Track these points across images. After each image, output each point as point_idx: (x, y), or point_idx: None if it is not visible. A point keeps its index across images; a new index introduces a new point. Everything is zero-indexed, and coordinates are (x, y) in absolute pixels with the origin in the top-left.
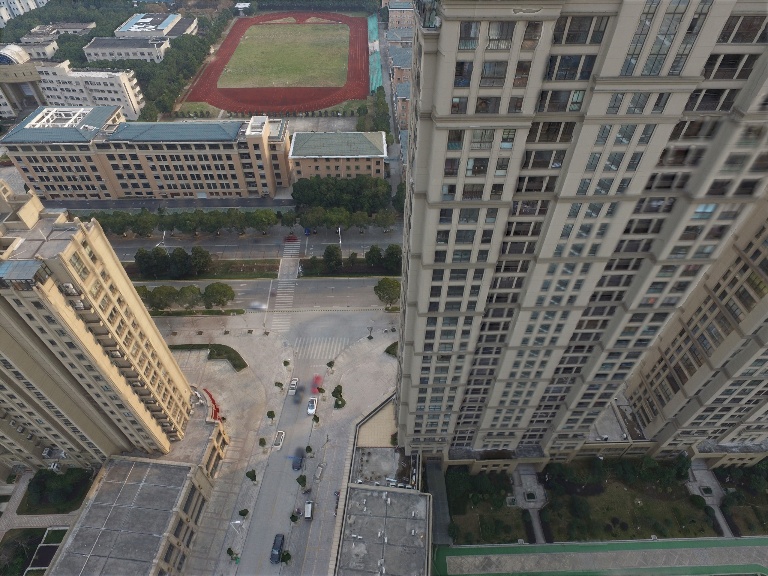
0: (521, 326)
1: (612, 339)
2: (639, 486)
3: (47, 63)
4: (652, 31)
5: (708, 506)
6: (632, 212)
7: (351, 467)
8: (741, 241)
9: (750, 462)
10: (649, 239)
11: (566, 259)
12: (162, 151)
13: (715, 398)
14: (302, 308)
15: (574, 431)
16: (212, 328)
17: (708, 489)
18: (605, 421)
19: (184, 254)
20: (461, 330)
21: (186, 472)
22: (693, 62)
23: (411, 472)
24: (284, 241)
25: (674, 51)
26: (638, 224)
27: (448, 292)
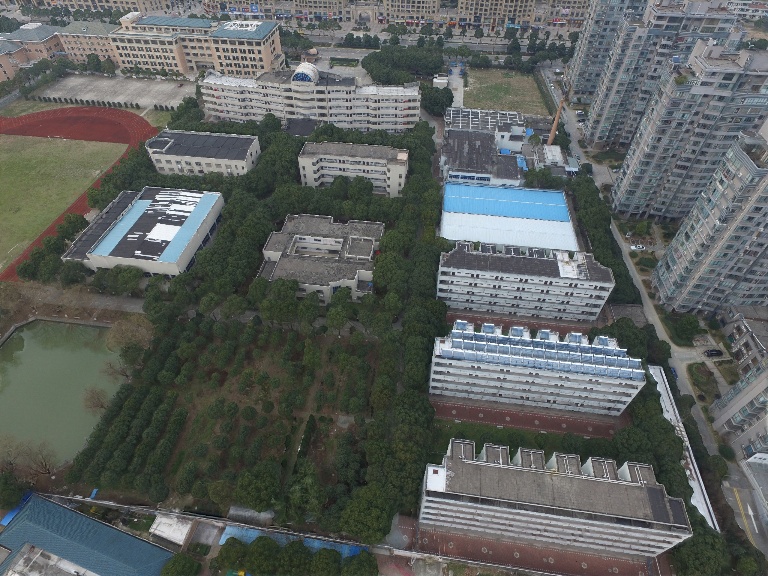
0: None
1: None
2: None
3: (275, 81)
4: None
5: None
6: None
7: None
8: None
9: None
10: None
11: None
12: None
13: None
14: None
15: None
16: None
17: None
18: None
19: None
20: None
21: None
22: None
23: None
24: None
25: None
26: None
27: None
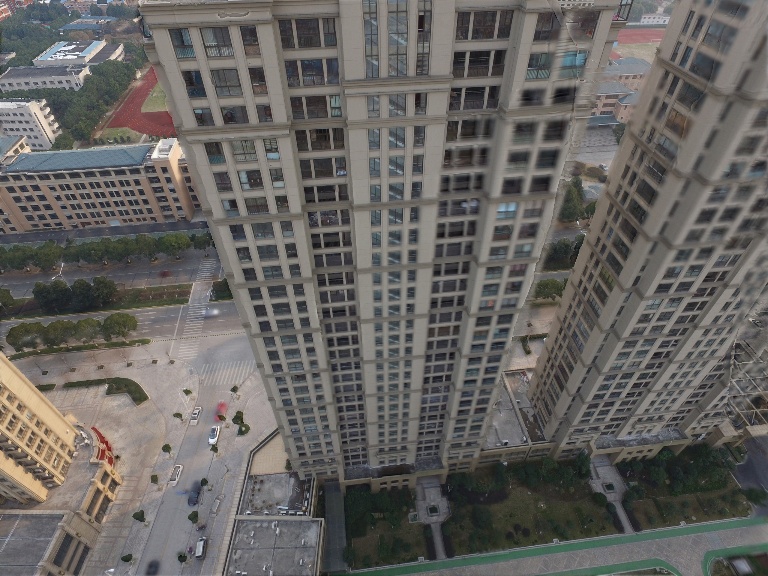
0: (368, 339)
1: (466, 345)
2: (542, 489)
3: None
4: (381, 31)
5: (609, 503)
6: (436, 216)
7: (241, 498)
8: (591, 236)
9: (650, 454)
10: (468, 242)
11: (386, 268)
12: (65, 180)
13: (593, 394)
14: (212, 333)
15: (466, 439)
16: (114, 361)
17: (610, 485)
18: (507, 425)
19: (86, 285)
20: (304, 348)
21: (59, 521)
22: (437, 61)
23: (304, 497)
24: (198, 264)
25: (412, 50)
26: (450, 227)
27: (274, 310)
